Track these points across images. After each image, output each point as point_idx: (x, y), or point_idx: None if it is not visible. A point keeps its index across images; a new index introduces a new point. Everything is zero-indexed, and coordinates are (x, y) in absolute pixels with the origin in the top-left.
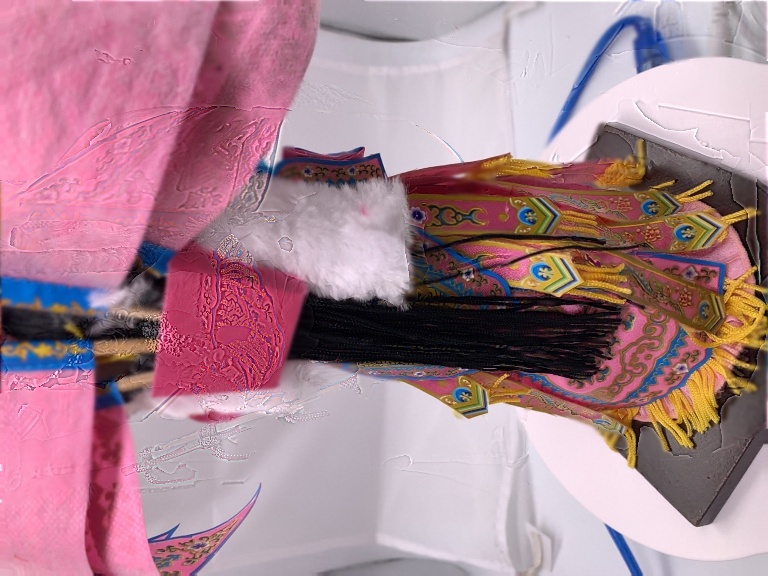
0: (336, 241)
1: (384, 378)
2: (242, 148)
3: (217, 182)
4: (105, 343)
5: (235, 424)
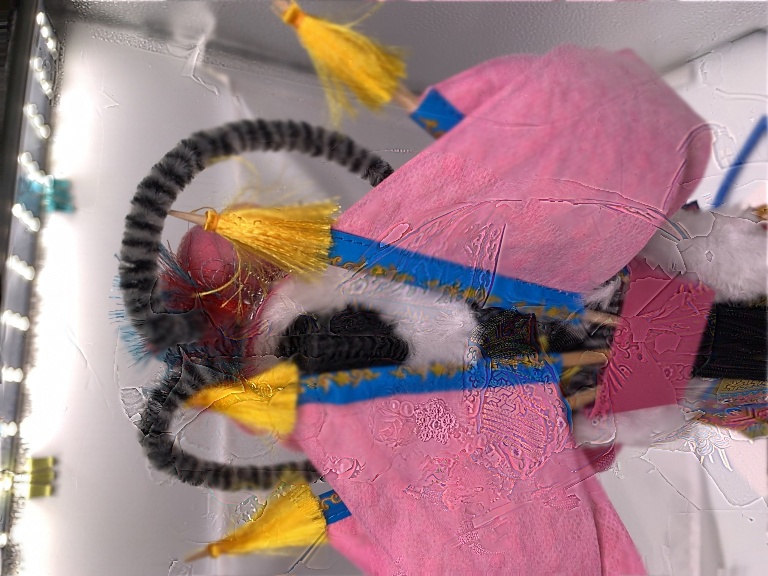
0: (751, 251)
1: (644, 450)
2: (480, 248)
3: (463, 278)
4: (389, 430)
5: (493, 516)
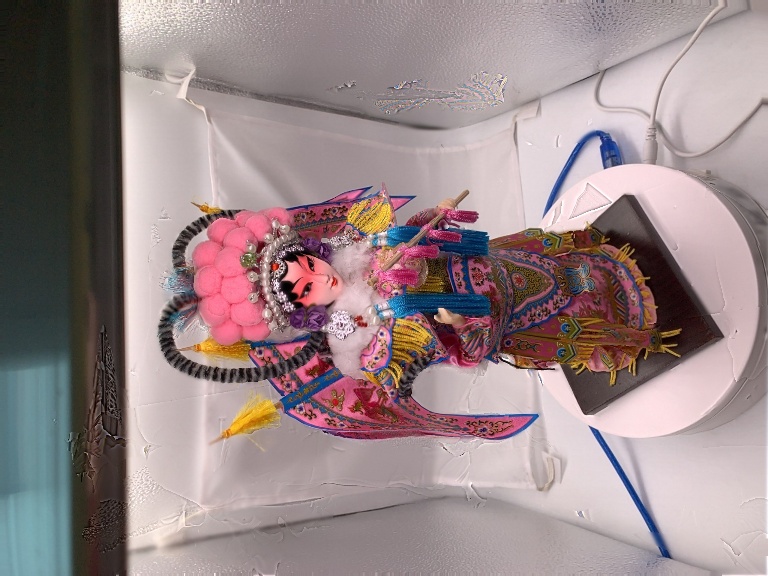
0: None
1: None
2: None
3: None
4: None
5: None
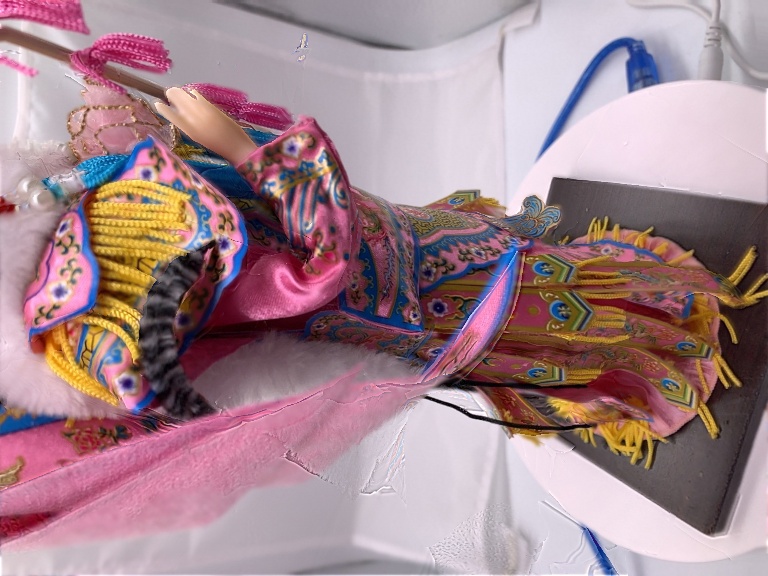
0: None
1: None
2: None
3: None
4: None
5: None
